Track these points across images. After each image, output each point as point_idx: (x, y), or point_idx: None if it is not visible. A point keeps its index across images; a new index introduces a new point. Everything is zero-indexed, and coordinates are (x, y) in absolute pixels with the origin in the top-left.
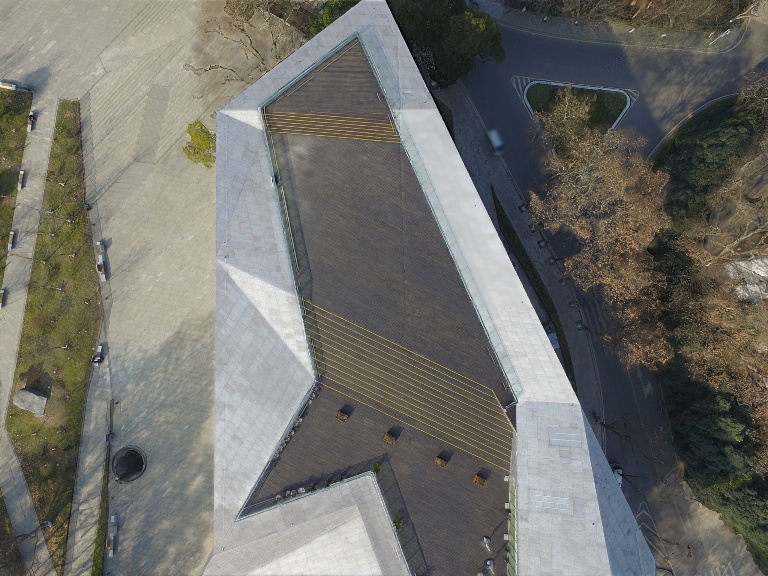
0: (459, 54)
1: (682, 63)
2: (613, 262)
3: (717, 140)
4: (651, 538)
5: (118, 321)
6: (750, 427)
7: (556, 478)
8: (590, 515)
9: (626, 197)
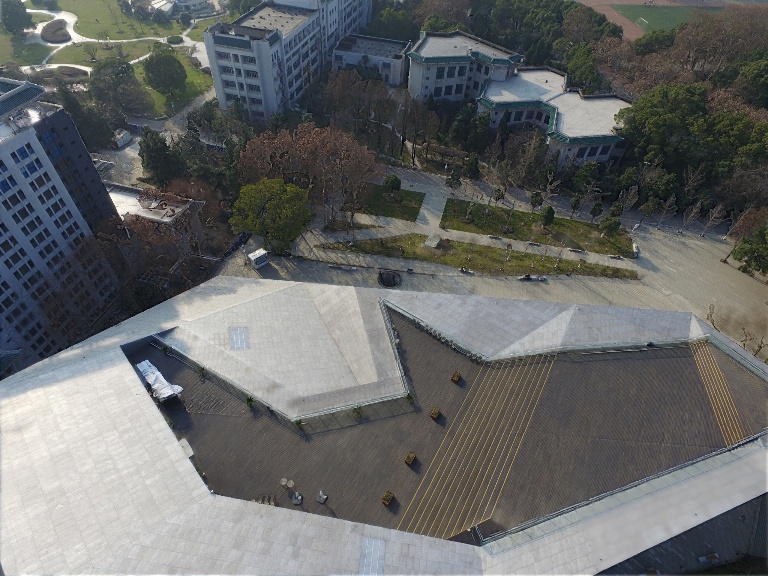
0: None
1: None
2: None
3: None
4: None
5: (491, 283)
6: None
7: (399, 574)
8: None
9: None
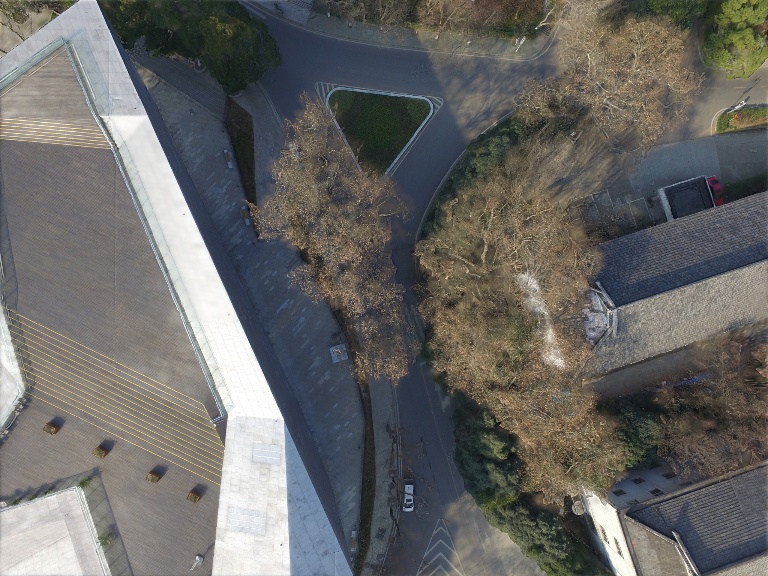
0: (223, 60)
1: (488, 70)
2: (332, 274)
3: (485, 149)
4: (448, 556)
5: None
6: (517, 444)
7: (254, 496)
8: (279, 535)
9: (332, 208)
